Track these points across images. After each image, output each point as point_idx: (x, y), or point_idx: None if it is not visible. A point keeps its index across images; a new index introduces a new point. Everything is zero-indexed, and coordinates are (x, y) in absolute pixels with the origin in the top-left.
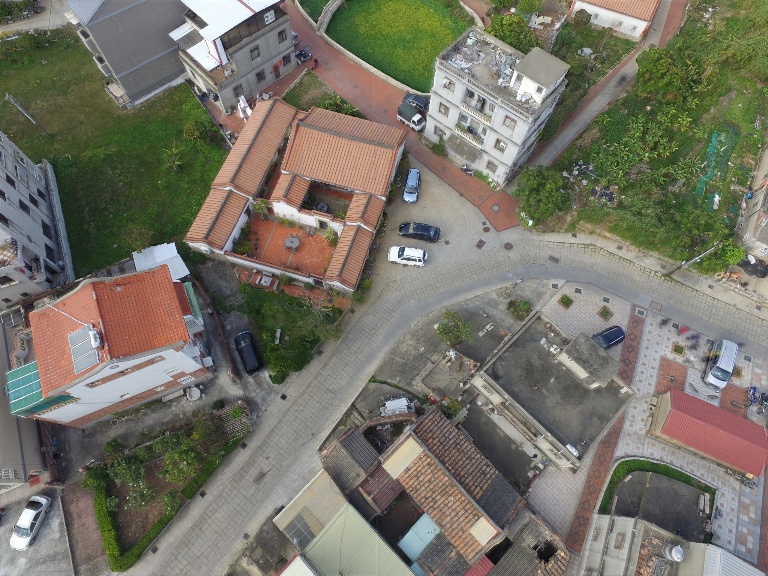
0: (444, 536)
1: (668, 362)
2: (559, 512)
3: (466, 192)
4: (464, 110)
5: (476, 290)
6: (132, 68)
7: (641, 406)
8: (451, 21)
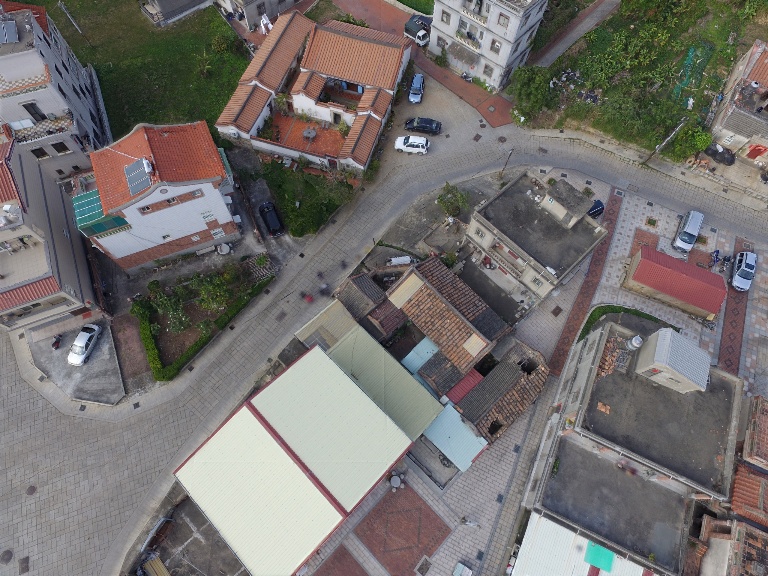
0: (441, 354)
1: (642, 232)
2: (542, 345)
3: (465, 96)
4: (464, 14)
5: (473, 174)
6: None
7: (617, 266)
8: None
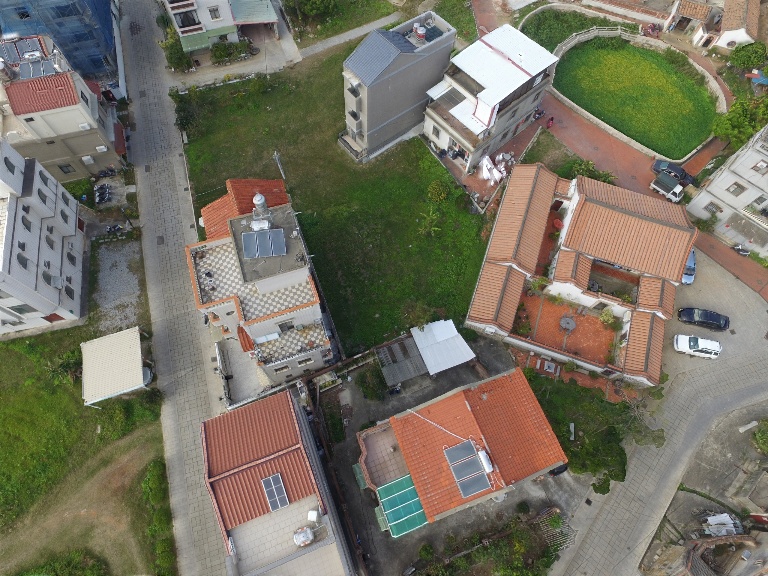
0: None
1: None
2: None
3: (742, 275)
4: None
5: None
6: (381, 124)
7: None
8: (678, 78)
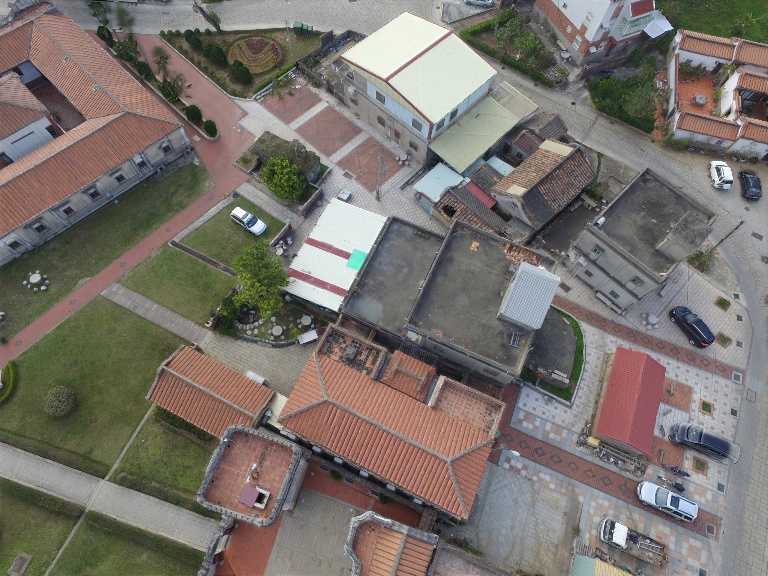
0: None
1: (688, 393)
2: None
3: None
4: None
5: None
6: None
7: None
8: None
